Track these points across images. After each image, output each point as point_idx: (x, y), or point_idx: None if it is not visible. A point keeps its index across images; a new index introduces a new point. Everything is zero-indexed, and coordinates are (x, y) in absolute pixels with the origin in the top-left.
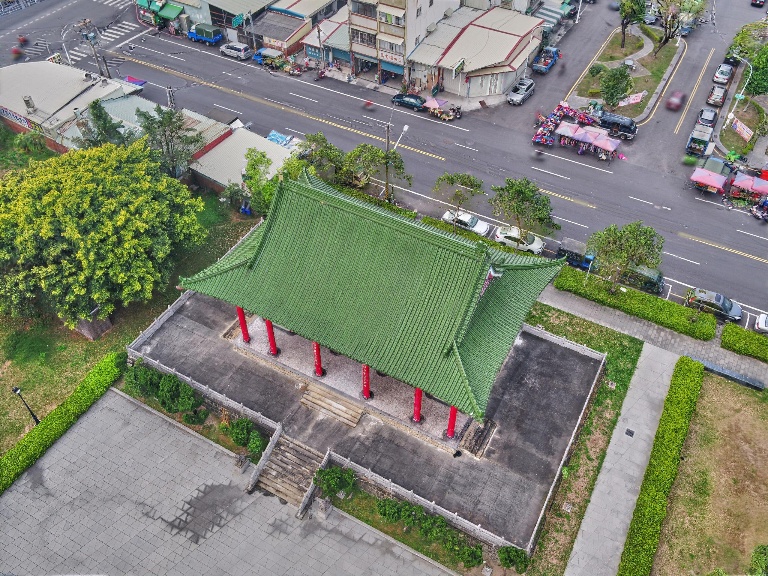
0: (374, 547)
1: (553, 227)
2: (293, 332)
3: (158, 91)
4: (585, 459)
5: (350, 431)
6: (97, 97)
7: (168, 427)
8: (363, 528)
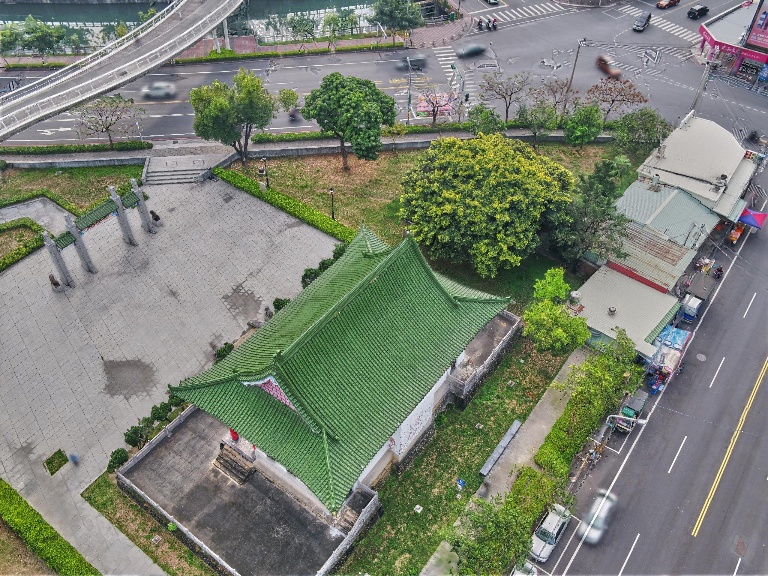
0: None
1: (458, 574)
2: None
3: (767, 247)
4: (195, 573)
5: None
6: (691, 189)
7: None
8: None
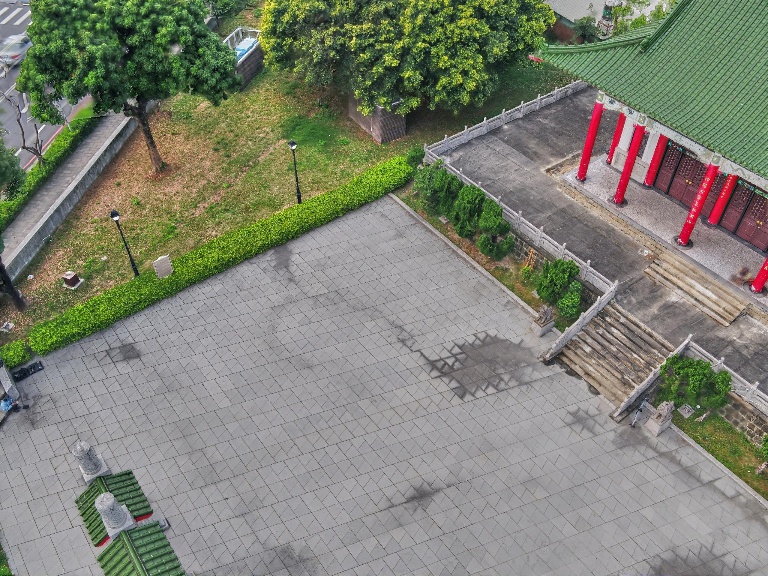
0: (733, 502)
1: None
2: (648, 186)
3: None
4: None
5: (718, 329)
6: None
7: (450, 254)
8: (717, 469)
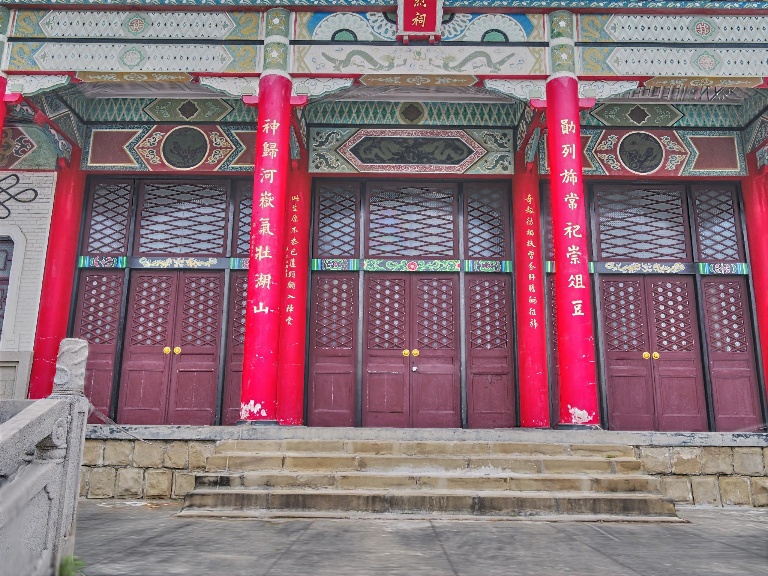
0: None
1: None
2: None
3: None
4: None
5: None
6: None
7: None
8: None
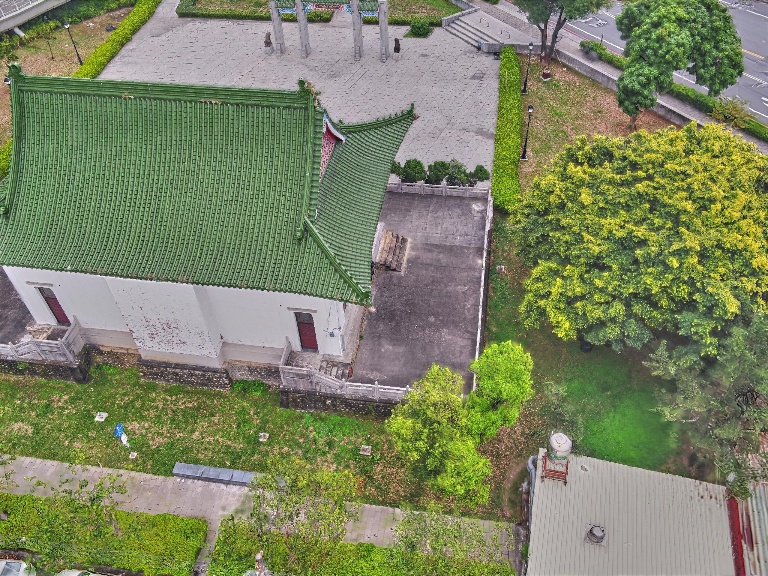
0: None
1: None
2: None
3: None
4: None
5: None
6: None
7: None
8: None
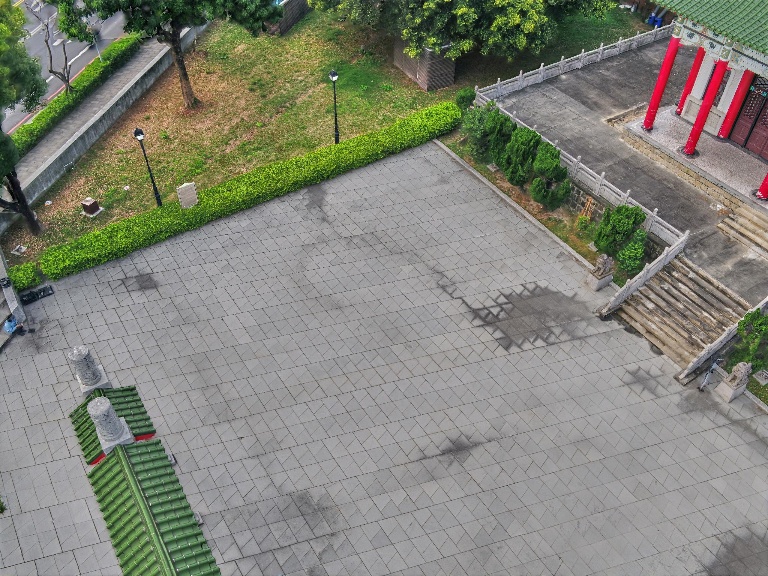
0: None
1: None
2: (722, 138)
3: None
4: None
5: None
6: None
7: (498, 202)
8: None
